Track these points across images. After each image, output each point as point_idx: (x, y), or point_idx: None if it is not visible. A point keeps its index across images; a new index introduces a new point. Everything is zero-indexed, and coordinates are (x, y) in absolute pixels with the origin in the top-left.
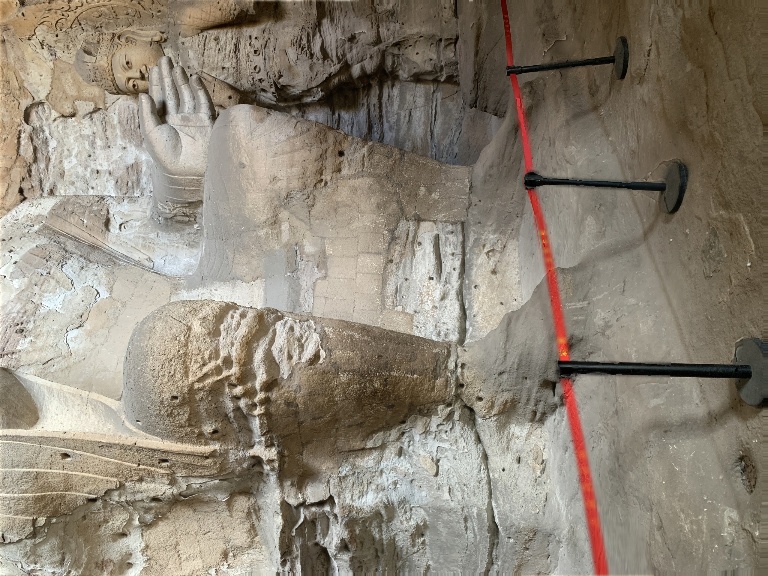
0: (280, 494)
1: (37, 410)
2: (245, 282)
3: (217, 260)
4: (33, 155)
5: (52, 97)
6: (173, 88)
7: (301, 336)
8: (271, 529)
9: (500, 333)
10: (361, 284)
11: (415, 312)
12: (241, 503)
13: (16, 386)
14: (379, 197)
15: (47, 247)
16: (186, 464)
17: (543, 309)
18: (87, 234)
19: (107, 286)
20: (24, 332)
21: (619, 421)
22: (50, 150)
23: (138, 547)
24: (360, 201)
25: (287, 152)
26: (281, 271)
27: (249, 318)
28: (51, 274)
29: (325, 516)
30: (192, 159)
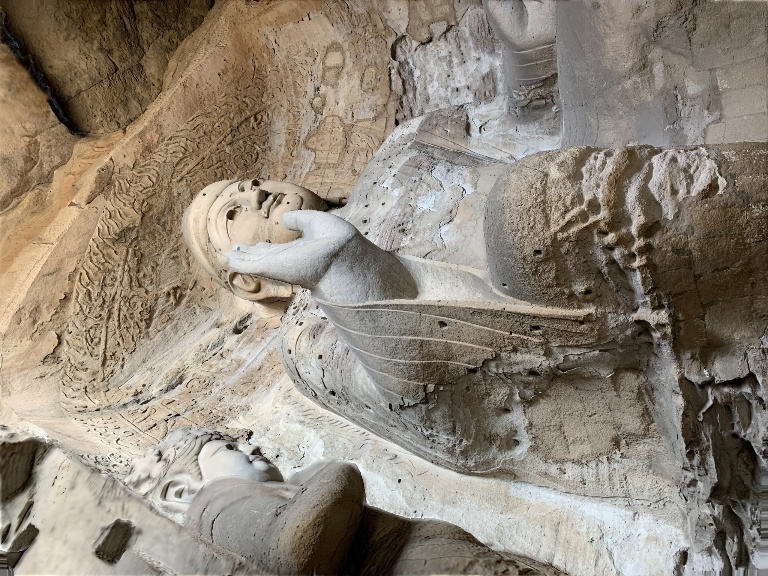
0: (677, 369)
1: (416, 286)
2: None
3: (579, 132)
4: (402, 87)
5: (411, 28)
6: None
7: (688, 165)
8: (670, 413)
9: None
10: None
11: None
12: (629, 381)
13: (397, 265)
14: None
15: (418, 158)
16: (559, 331)
17: None
18: (451, 143)
19: (472, 183)
20: (405, 231)
21: None
22: (415, 80)
23: (522, 424)
24: (766, 2)
25: None
26: (658, 126)
27: (616, 155)
28: (423, 179)
29: (744, 400)
30: (540, 25)
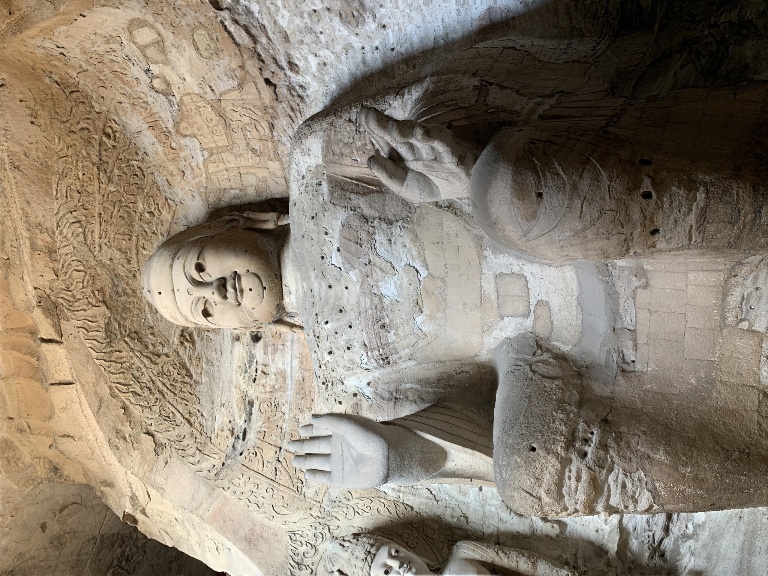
0: None
1: (443, 448)
2: (553, 267)
3: None
4: (249, 37)
5: None
6: None
7: (634, 493)
8: None
9: None
10: (693, 296)
11: (766, 329)
12: None
13: (424, 445)
14: (716, 255)
15: (350, 222)
16: None
17: None
18: (366, 169)
19: (420, 260)
20: (386, 328)
21: None
22: (257, 16)
23: None
24: None
25: (577, 244)
26: (592, 271)
27: (584, 483)
28: (372, 262)
29: None
30: (455, 195)
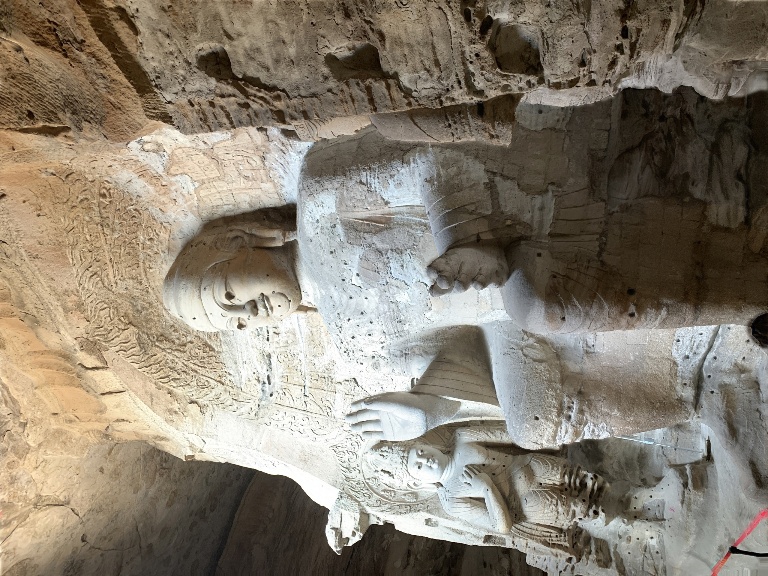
0: None
1: None
2: None
3: None
4: None
5: None
6: None
7: None
8: None
9: (720, 441)
10: None
11: None
12: None
13: (447, 403)
14: None
15: (367, 256)
16: None
17: (741, 479)
18: None
19: None
20: (402, 322)
21: (745, 521)
22: None
23: None
24: None
25: None
26: None
27: (570, 434)
28: (389, 283)
29: None
30: None
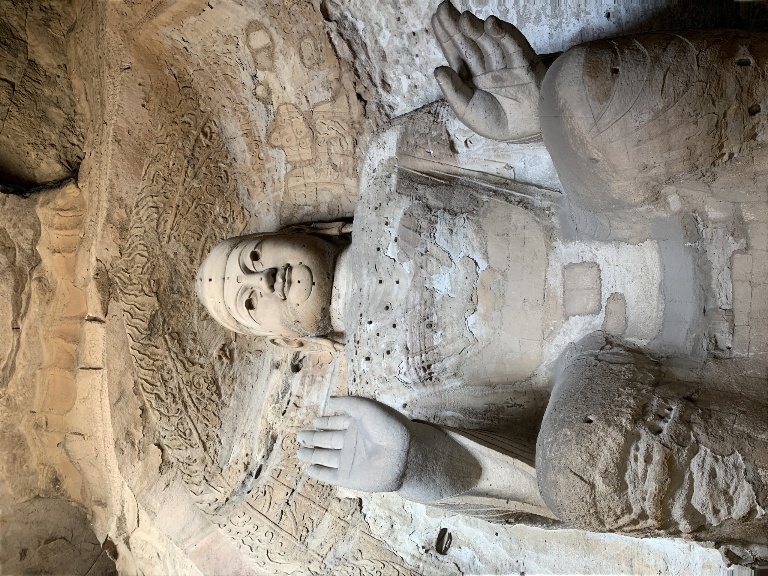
0: (724, 546)
1: (477, 461)
2: (631, 244)
3: (589, 224)
4: (350, 52)
5: None
6: (468, 42)
7: (727, 486)
8: None
9: None
10: None
11: None
12: None
13: (455, 449)
14: None
15: (413, 211)
16: None
17: None
18: (438, 164)
19: (481, 251)
20: (433, 327)
21: None
22: (361, 34)
23: None
24: None
25: (657, 134)
26: (678, 238)
27: (656, 465)
28: (429, 251)
29: None
30: (523, 125)
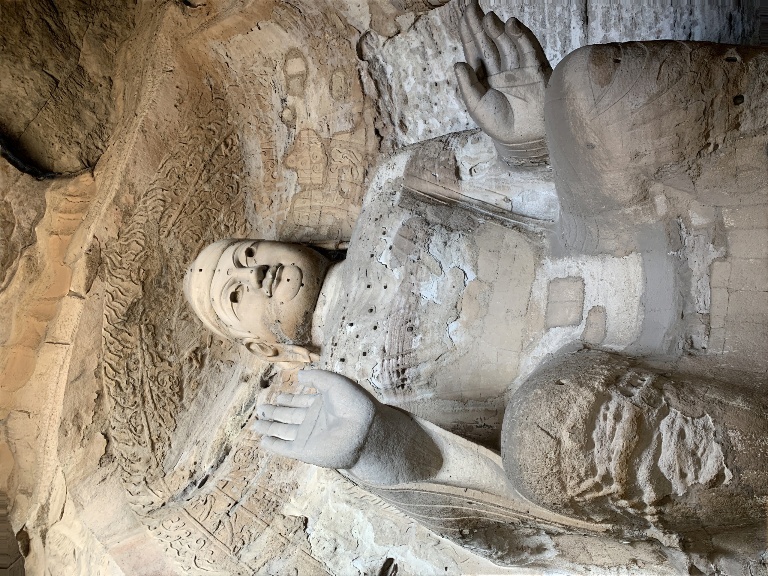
0: (688, 560)
1: (440, 452)
2: (616, 257)
3: (579, 234)
4: (376, 90)
5: (374, 23)
6: (488, 42)
7: (696, 447)
8: None
9: None
10: None
11: None
12: (644, 546)
13: (419, 434)
14: None
15: (411, 223)
16: None
17: None
18: (442, 188)
19: (472, 263)
20: (414, 330)
21: None
22: (389, 77)
23: (549, 543)
24: None
25: (650, 119)
26: (661, 247)
27: (625, 423)
28: (421, 259)
29: None
30: (528, 125)
